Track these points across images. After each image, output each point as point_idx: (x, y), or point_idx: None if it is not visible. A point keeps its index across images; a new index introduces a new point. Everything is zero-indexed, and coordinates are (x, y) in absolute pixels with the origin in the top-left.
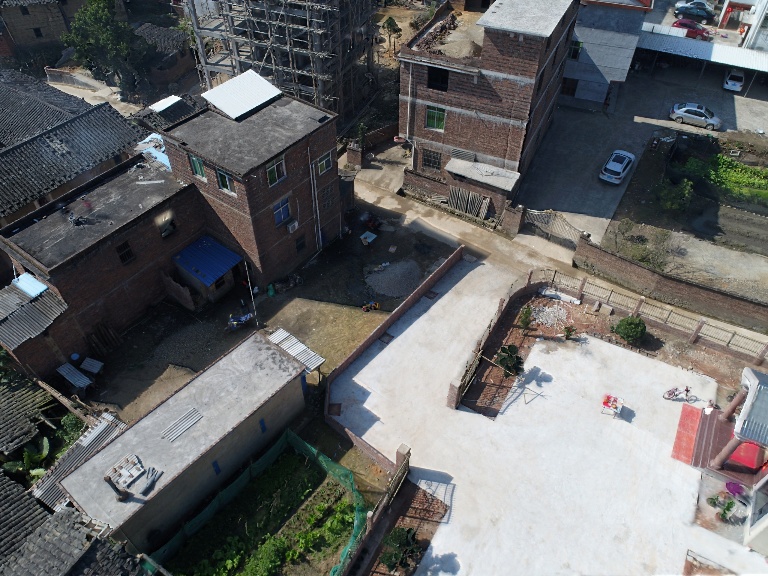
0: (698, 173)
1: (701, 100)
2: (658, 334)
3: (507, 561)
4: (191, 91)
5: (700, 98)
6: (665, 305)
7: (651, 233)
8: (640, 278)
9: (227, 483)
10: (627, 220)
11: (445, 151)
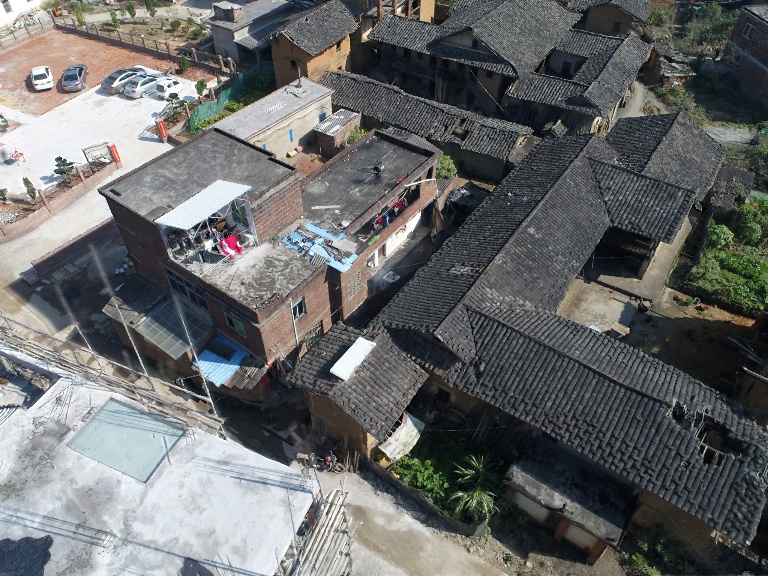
0: None
1: None
2: None
3: (128, 115)
4: None
5: None
6: None
7: None
8: None
9: None
10: None
11: None
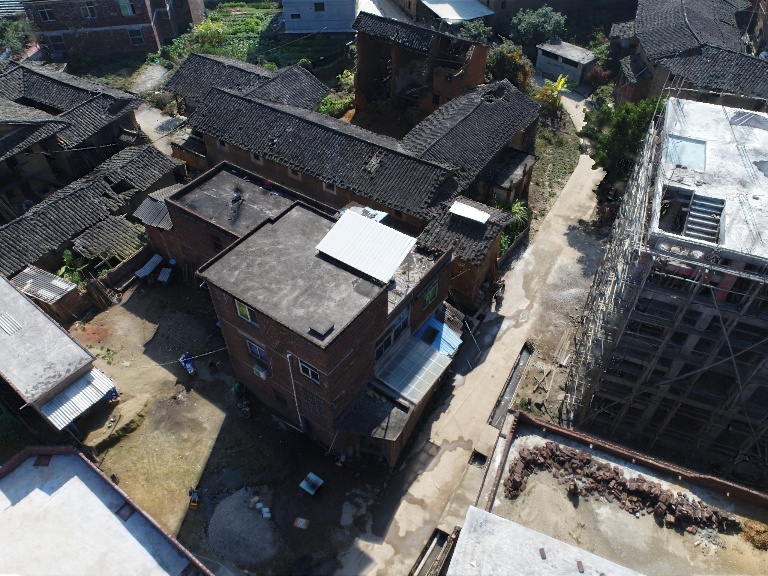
0: None
1: None
2: None
3: None
4: None
5: None
6: None
7: None
8: None
9: (8, 385)
10: None
11: None
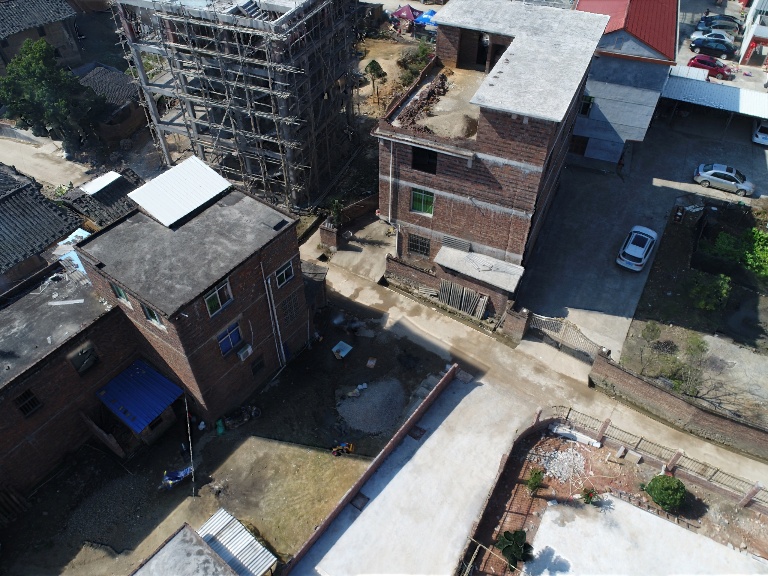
0: (733, 257)
1: (728, 156)
2: (699, 493)
3: None
4: (146, 148)
5: (727, 154)
6: (704, 443)
7: (681, 338)
8: (672, 407)
9: None
10: (653, 326)
11: (434, 237)
